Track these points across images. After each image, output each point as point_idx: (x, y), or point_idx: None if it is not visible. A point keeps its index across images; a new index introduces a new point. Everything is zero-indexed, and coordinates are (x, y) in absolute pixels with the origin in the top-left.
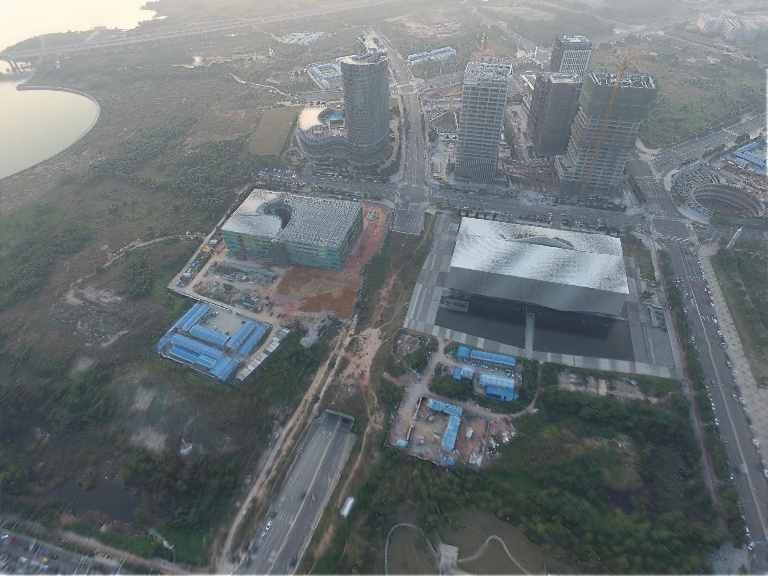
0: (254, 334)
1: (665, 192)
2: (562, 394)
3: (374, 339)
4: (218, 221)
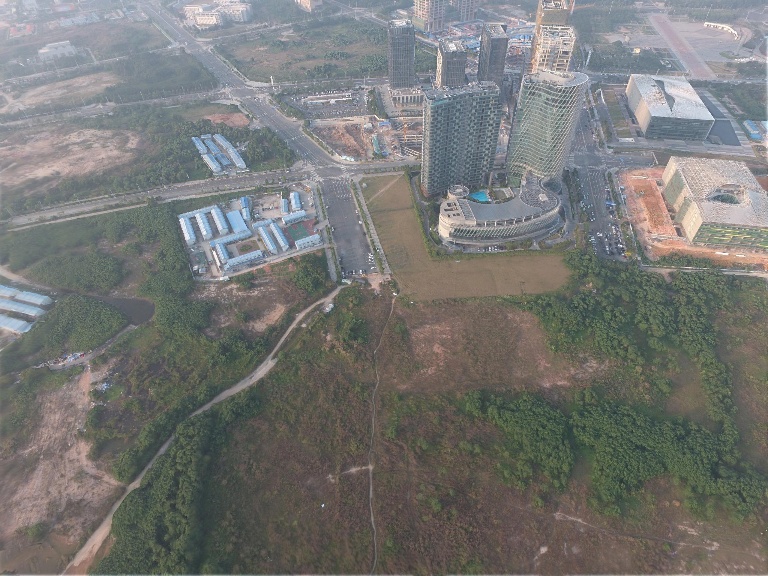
0: None
1: None
2: (758, 109)
3: None
4: None
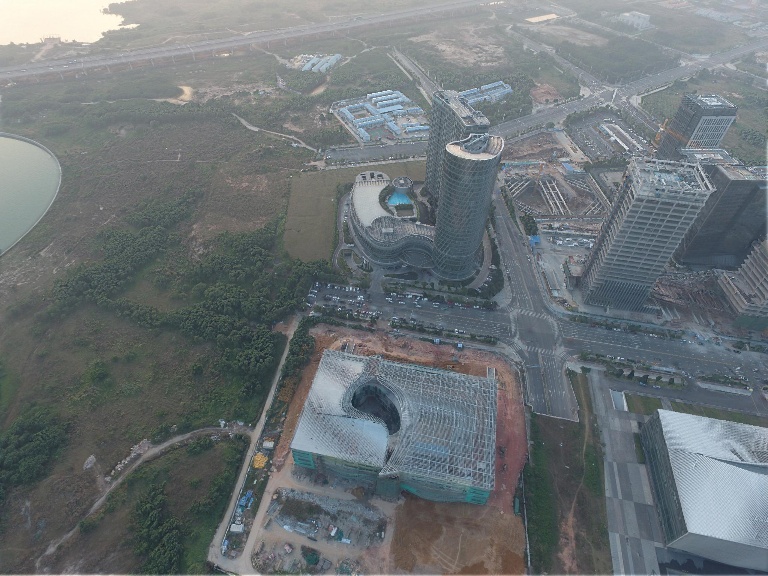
0: None
1: None
2: None
3: None
4: (266, 395)
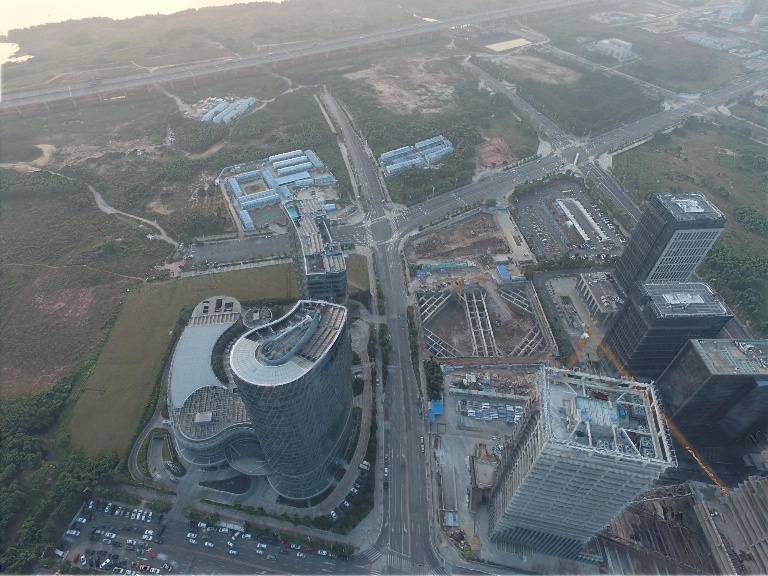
0: None
1: None
2: None
3: None
4: None
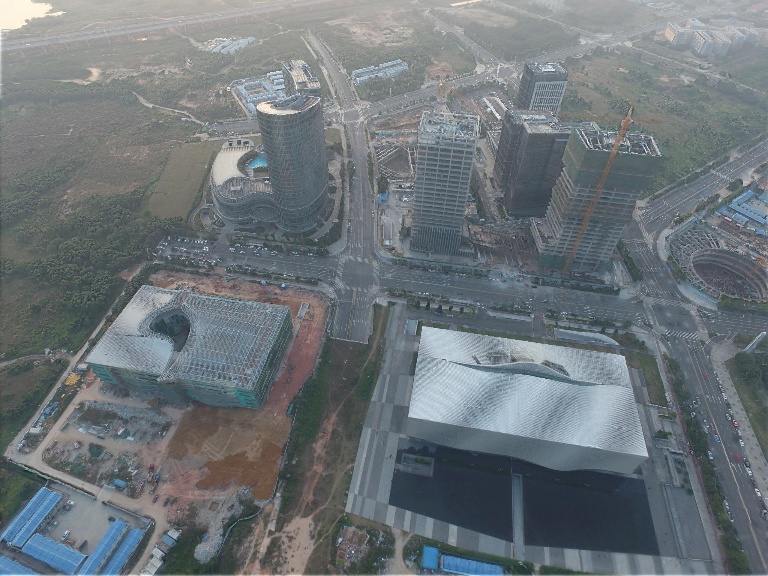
0: (124, 545)
1: (661, 262)
2: None
3: (303, 539)
4: (94, 328)
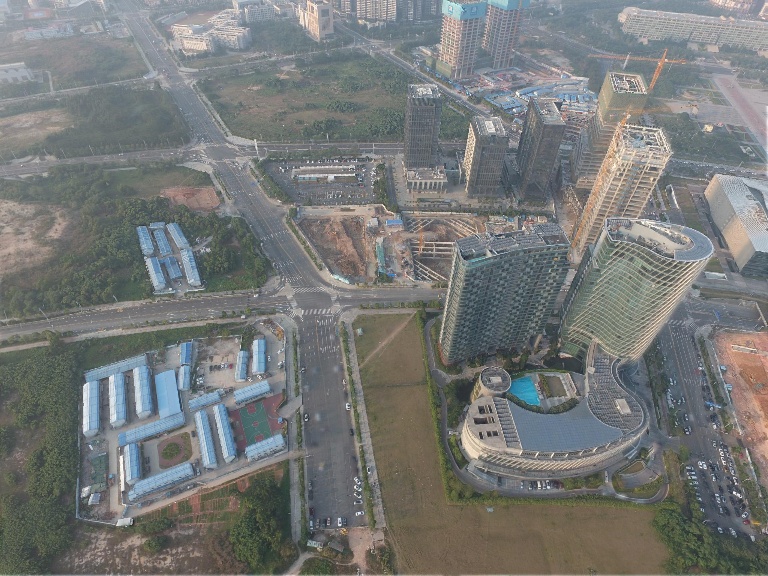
0: None
1: None
2: None
3: None
4: None
